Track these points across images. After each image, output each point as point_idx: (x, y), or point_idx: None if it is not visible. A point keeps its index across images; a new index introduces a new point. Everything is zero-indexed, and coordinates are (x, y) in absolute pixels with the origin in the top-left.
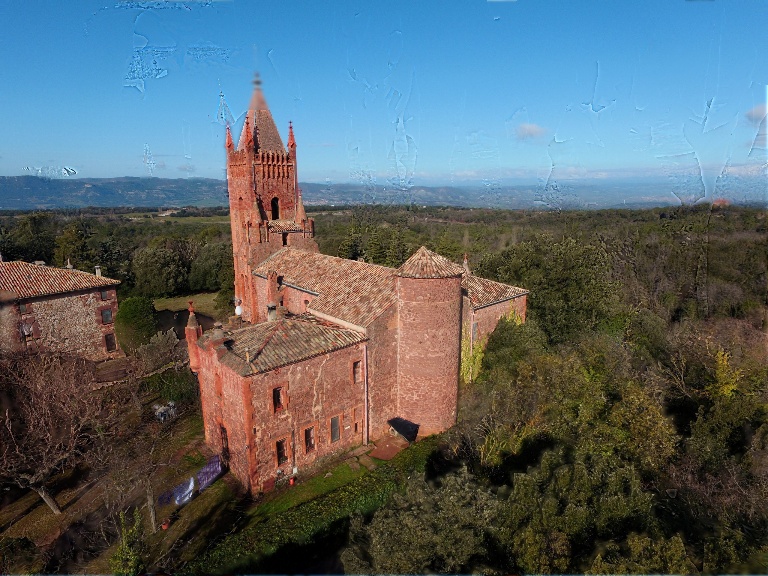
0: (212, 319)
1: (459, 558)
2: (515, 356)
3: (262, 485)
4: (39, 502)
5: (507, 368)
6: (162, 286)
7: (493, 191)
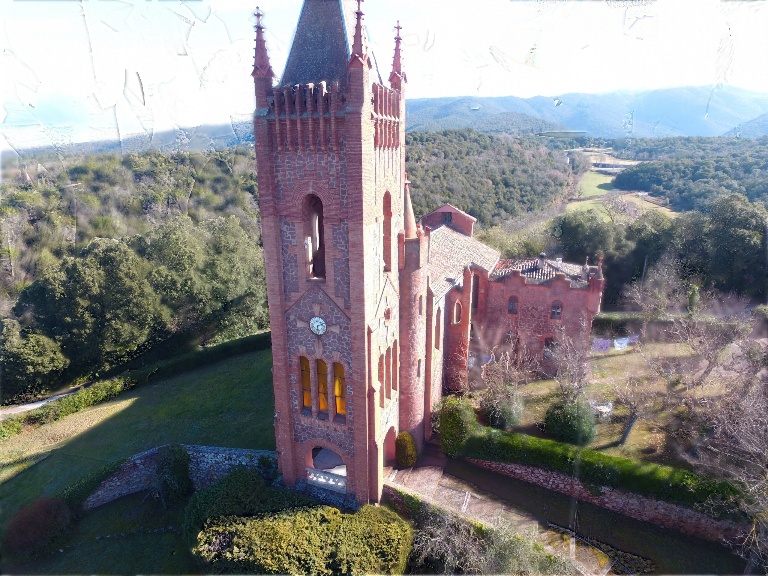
0: None
1: None
2: None
3: None
4: (715, 399)
5: None
6: None
7: None
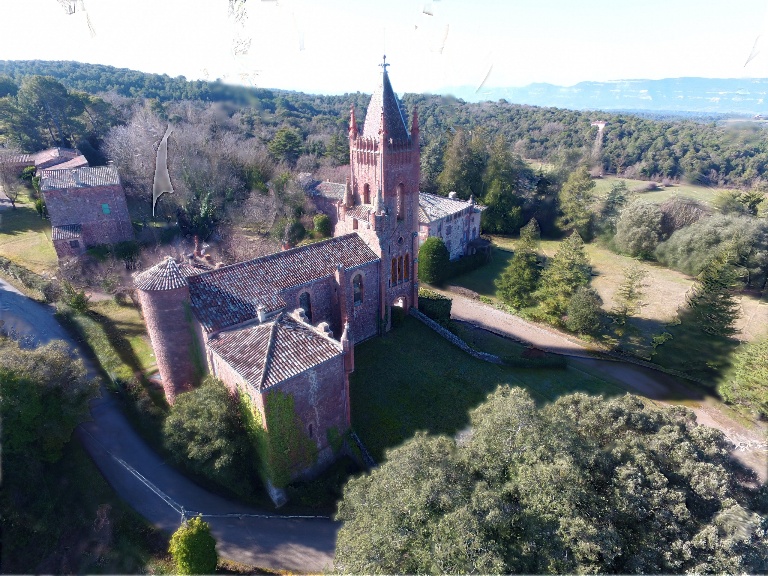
0: None
1: None
2: None
3: None
4: None
5: None
6: (624, 245)
7: None
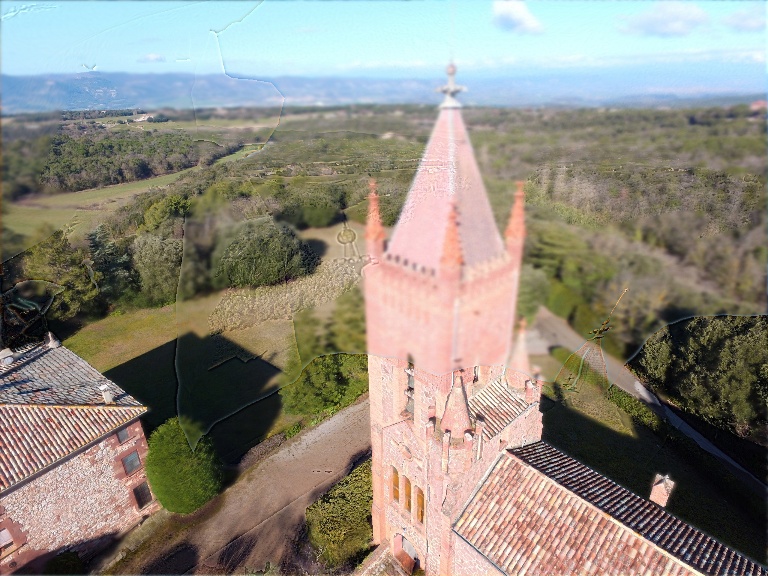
0: None
1: None
2: None
3: None
4: None
5: None
6: None
7: None
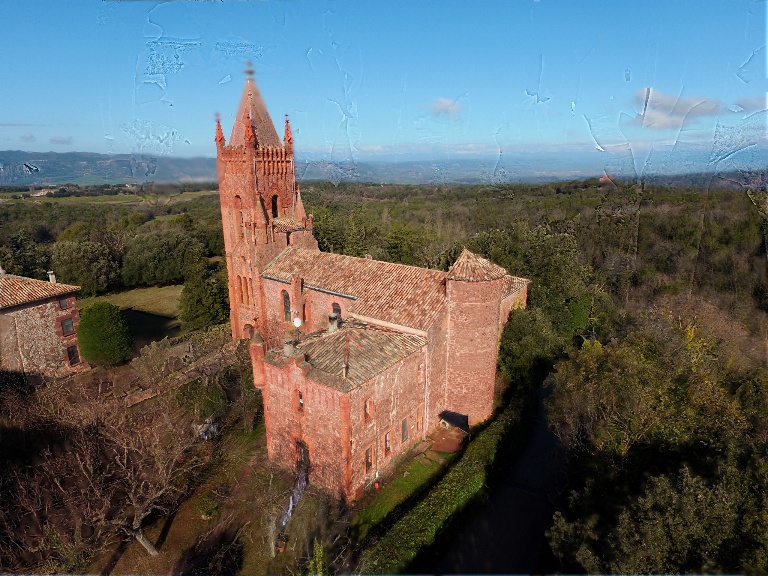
0: (167, 318)
1: (714, 544)
2: (533, 343)
3: (355, 493)
4: (123, 545)
5: (530, 355)
6: (92, 284)
7: (441, 176)
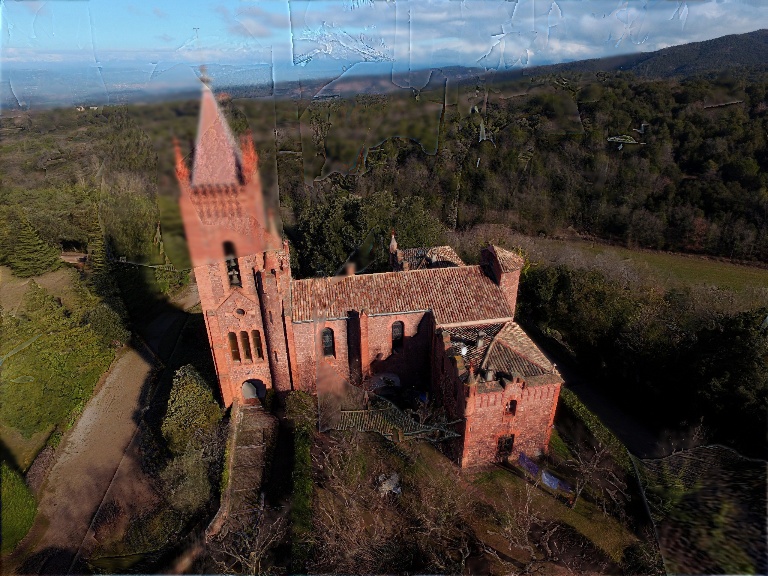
0: None
1: None
2: None
3: None
4: None
5: None
6: None
7: None
